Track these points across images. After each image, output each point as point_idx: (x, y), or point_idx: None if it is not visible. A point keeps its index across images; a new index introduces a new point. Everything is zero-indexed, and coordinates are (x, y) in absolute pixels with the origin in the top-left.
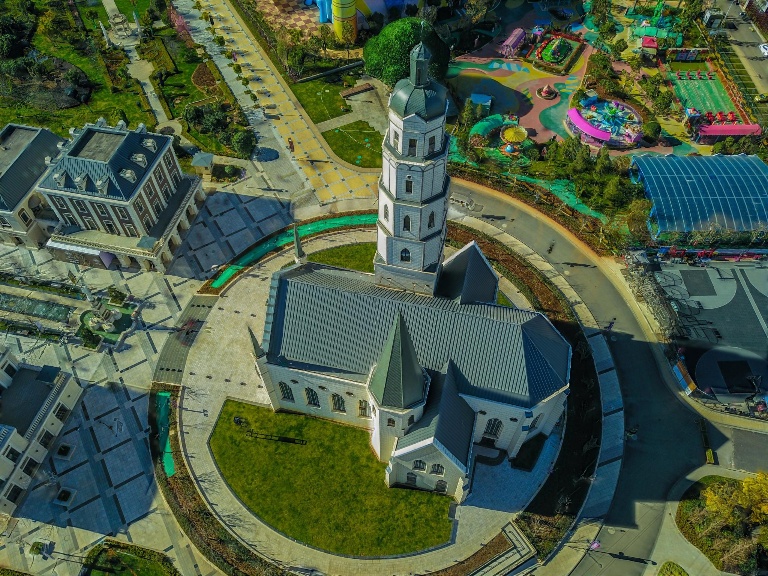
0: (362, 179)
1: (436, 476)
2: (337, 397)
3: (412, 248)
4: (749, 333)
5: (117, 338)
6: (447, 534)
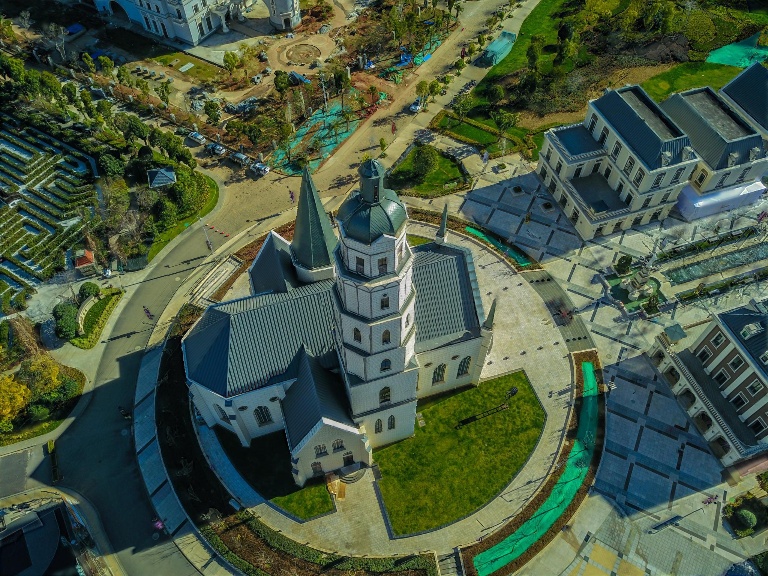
0: None
1: None
2: None
3: None
4: None
5: (610, 283)
6: None
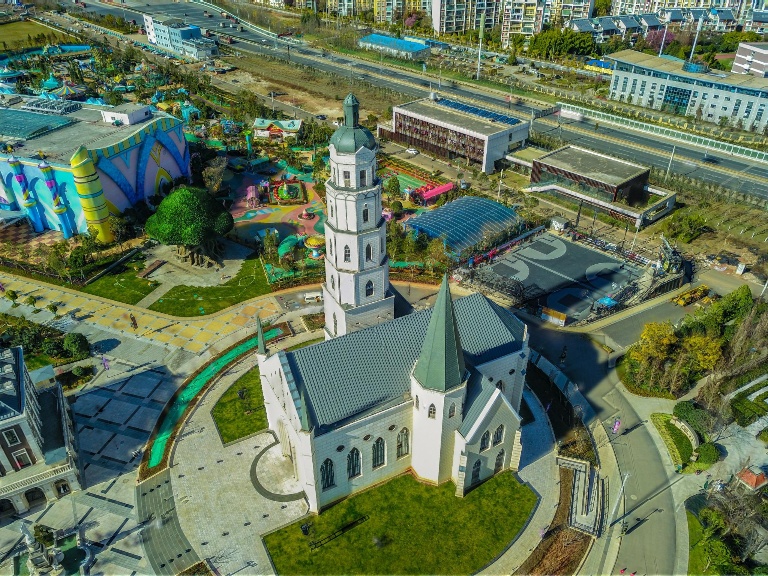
0: (218, 321)
1: (498, 447)
2: (376, 446)
3: (374, 277)
4: (555, 280)
5: None
6: (532, 494)
